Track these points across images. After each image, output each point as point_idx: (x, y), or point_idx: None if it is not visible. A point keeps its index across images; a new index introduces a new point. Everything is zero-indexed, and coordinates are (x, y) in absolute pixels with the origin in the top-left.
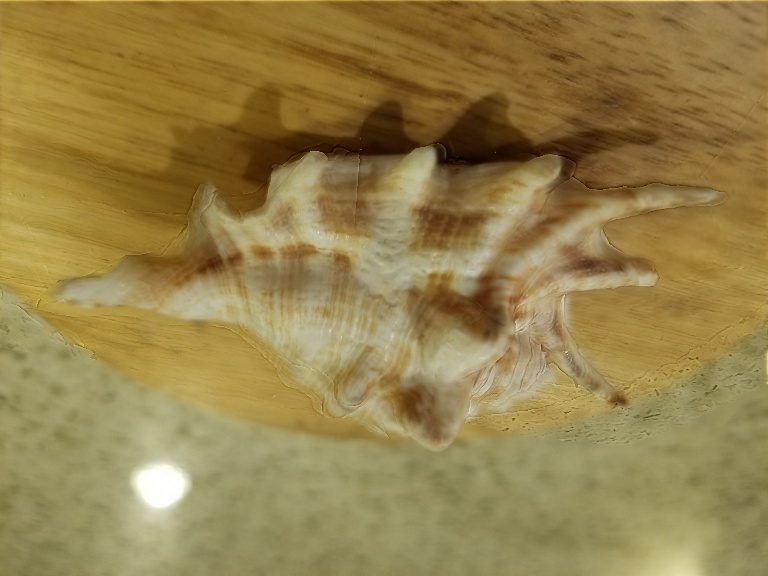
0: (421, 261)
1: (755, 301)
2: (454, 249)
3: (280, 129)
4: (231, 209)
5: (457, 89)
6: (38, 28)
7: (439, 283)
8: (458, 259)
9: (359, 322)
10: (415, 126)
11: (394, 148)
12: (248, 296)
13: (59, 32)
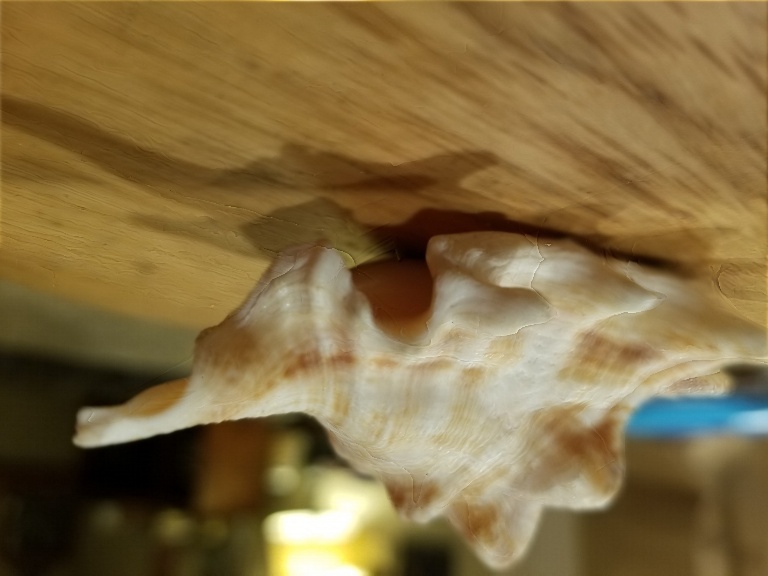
0: (565, 389)
1: None
2: (604, 383)
3: (454, 186)
4: (381, 313)
5: (700, 216)
6: (173, 1)
7: (569, 408)
8: (603, 392)
9: (474, 441)
10: (617, 226)
11: (577, 239)
12: (359, 404)
13: (211, 19)
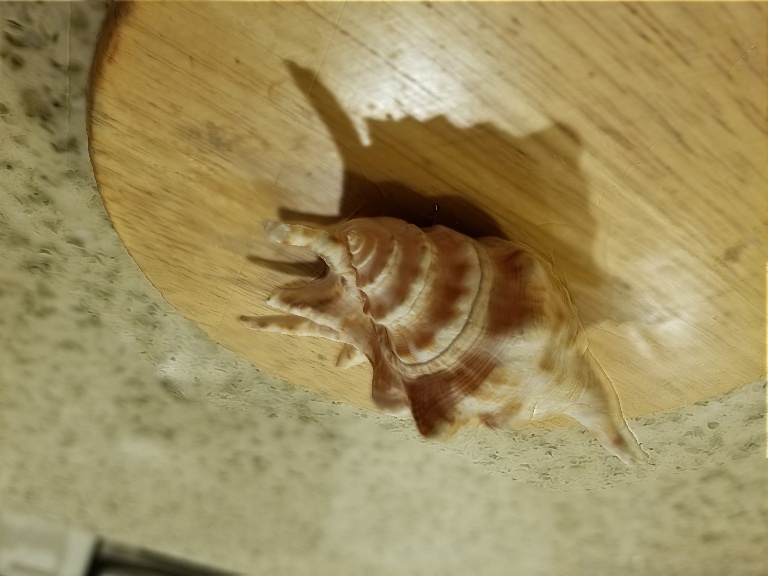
0: None
1: (110, 106)
2: None
3: None
4: None
5: None
6: None
7: None
8: None
9: None
10: None
11: None
12: None
13: None
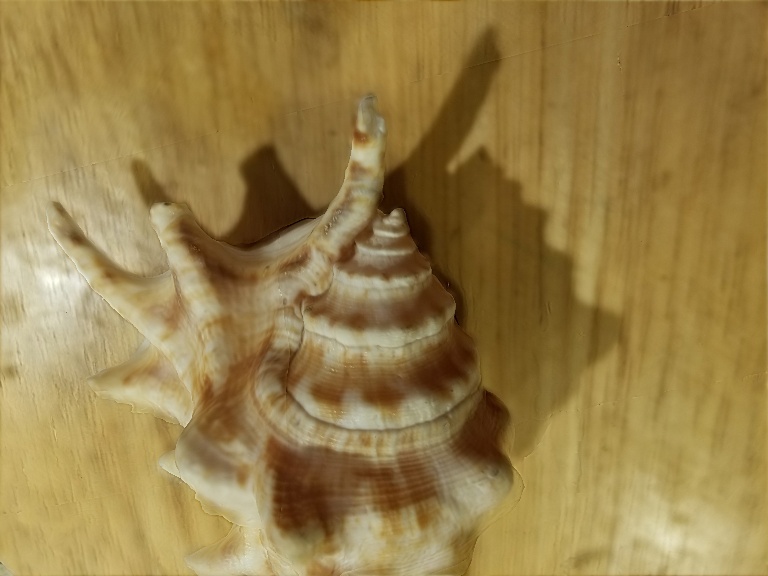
0: None
1: None
2: None
3: None
4: None
5: (160, 423)
6: None
7: None
8: None
9: None
10: None
11: None
12: None
13: None
